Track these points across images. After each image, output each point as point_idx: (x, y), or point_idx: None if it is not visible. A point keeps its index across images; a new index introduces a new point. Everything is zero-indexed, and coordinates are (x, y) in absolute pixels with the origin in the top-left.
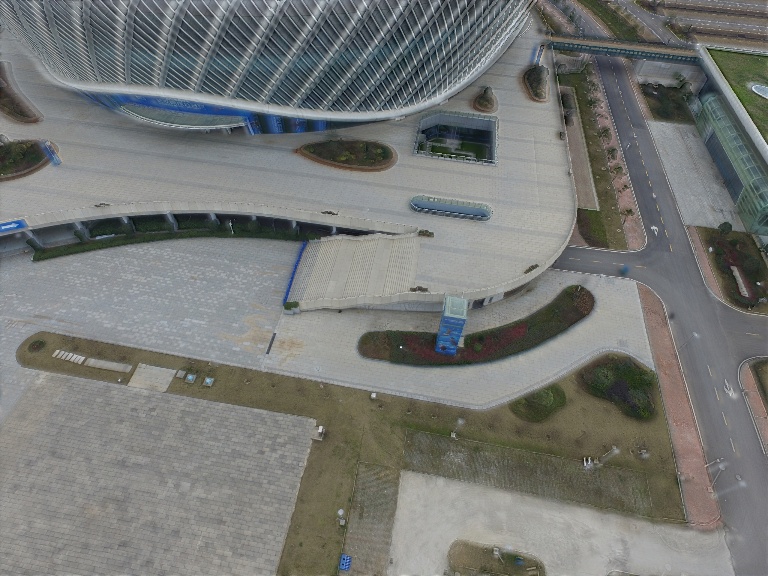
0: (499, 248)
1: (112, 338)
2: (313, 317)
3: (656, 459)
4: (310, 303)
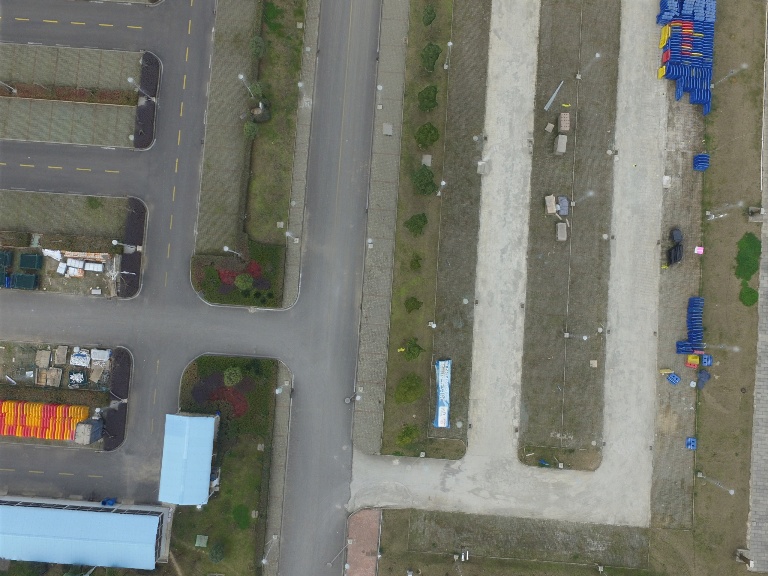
0: None
1: None
2: None
3: (396, 567)
4: None
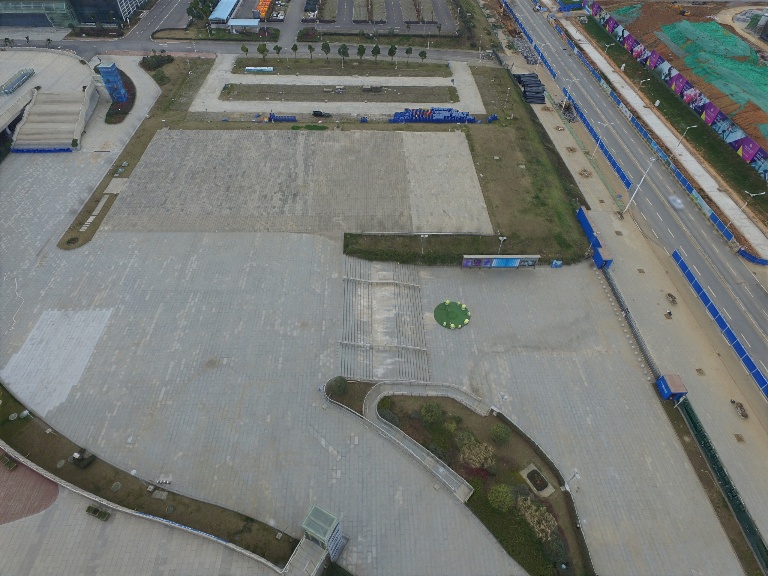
0: (61, 70)
1: (76, 211)
2: (86, 140)
3: (192, 60)
4: (76, 134)
